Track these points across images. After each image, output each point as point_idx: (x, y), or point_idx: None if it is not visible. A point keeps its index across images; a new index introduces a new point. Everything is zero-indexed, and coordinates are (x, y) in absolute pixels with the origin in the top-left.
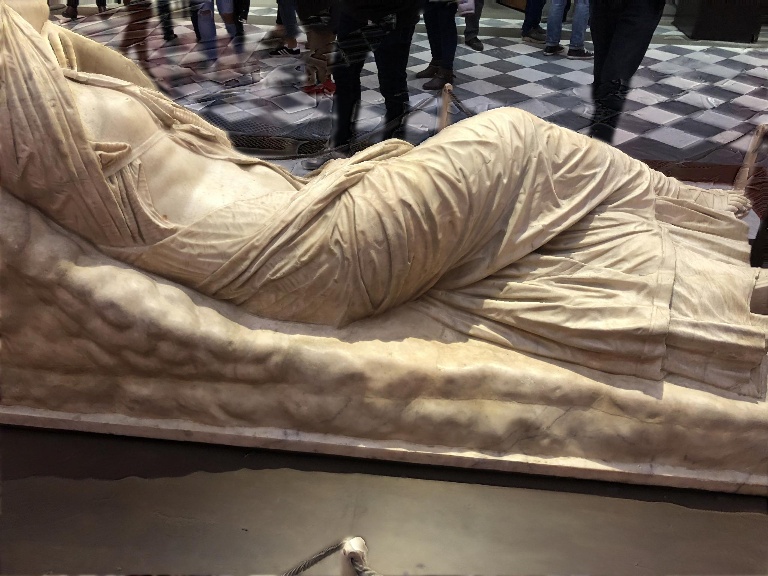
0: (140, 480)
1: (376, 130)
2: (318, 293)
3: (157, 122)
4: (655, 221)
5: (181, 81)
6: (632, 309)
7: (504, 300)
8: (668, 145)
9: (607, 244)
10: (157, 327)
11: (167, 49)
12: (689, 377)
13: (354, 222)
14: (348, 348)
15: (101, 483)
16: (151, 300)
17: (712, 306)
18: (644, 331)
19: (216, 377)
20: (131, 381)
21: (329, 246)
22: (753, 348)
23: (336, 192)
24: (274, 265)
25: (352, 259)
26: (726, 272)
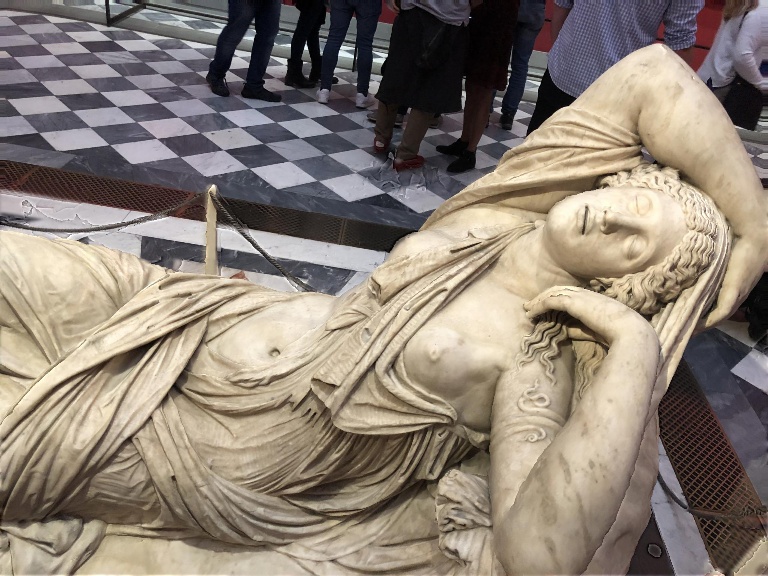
0: None
1: None
2: None
3: None
4: None
5: None
6: None
7: None
8: None
9: None
10: None
11: None
12: None
13: None
14: None
15: None
16: None
17: None
18: None
19: None
20: None
21: None
22: None
23: None
24: None
25: None
26: None
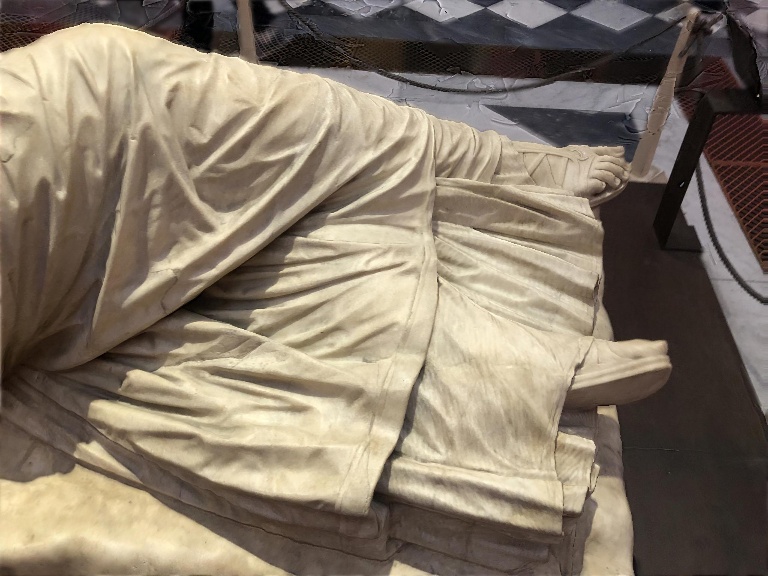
0: None
1: (151, 22)
2: None
3: None
4: (426, 235)
5: None
6: (317, 452)
7: (128, 400)
8: (603, 26)
9: (313, 295)
10: None
11: None
12: (441, 552)
13: None
14: None
15: None
16: None
17: (482, 432)
18: (327, 505)
19: None
20: None
21: None
22: (540, 532)
23: None
24: None
25: None
26: (519, 359)
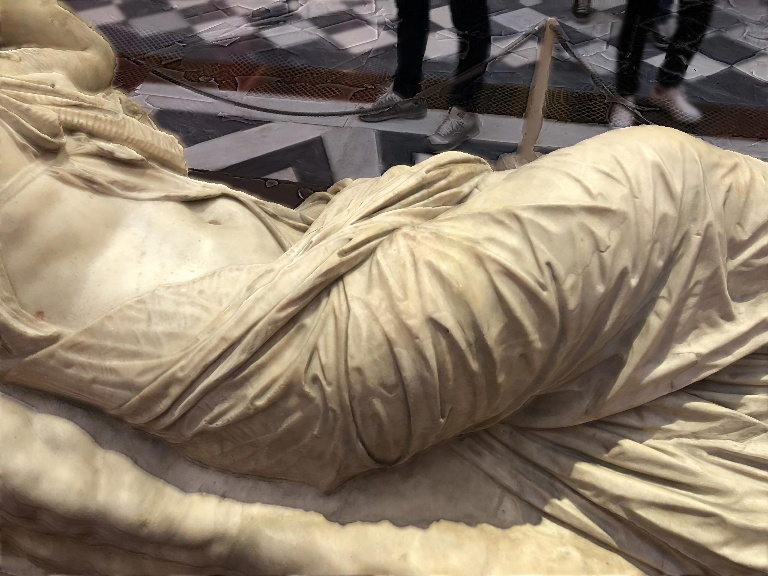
0: None
1: (450, 80)
2: (289, 447)
3: (27, 150)
4: None
5: (201, 8)
6: None
7: (610, 466)
8: None
9: None
10: (26, 497)
11: None
12: None
13: (345, 350)
14: (335, 537)
15: None
16: (17, 453)
17: None
18: None
19: (135, 552)
20: (24, 533)
21: (302, 386)
22: None
23: (321, 284)
24: (212, 406)
25: (341, 410)
26: None
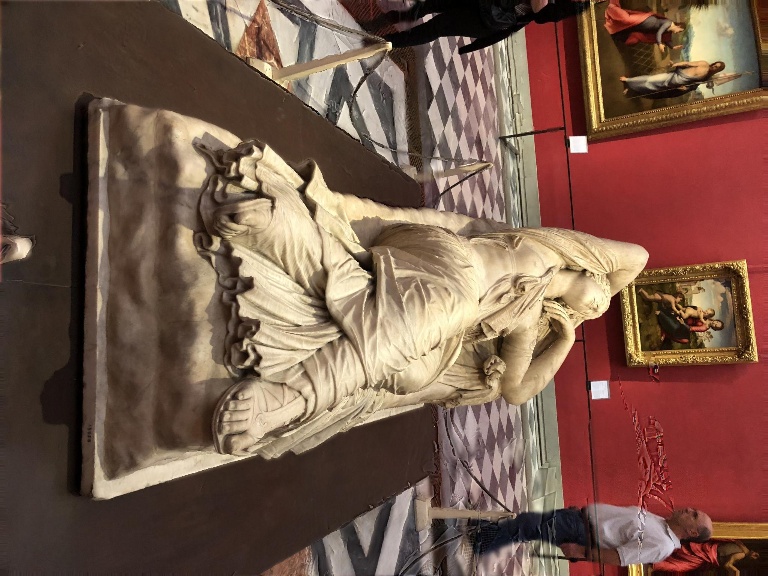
0: (359, 196)
1: None
2: None
3: None
4: None
5: None
6: None
7: None
8: None
9: None
10: None
11: (520, 574)
12: None
13: None
14: (377, 211)
15: (366, 196)
16: (444, 217)
17: (287, 188)
18: None
19: None
20: None
21: None
22: None
23: None
24: None
25: None
26: None
